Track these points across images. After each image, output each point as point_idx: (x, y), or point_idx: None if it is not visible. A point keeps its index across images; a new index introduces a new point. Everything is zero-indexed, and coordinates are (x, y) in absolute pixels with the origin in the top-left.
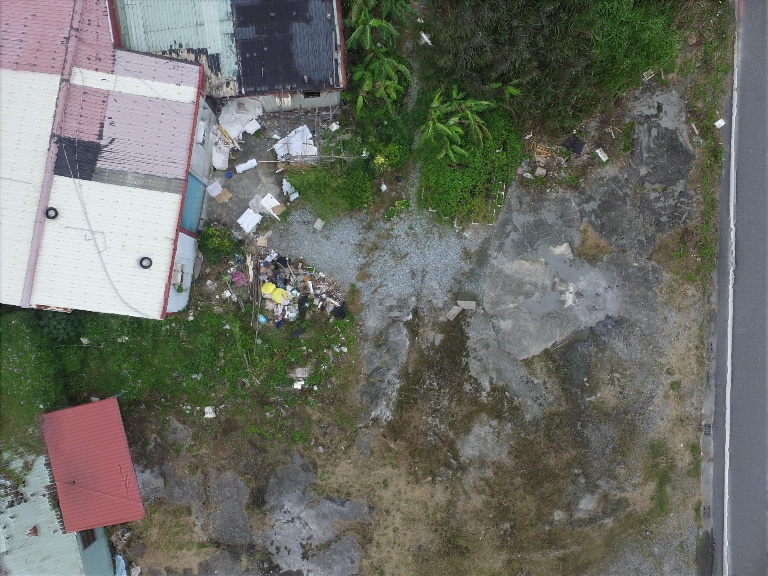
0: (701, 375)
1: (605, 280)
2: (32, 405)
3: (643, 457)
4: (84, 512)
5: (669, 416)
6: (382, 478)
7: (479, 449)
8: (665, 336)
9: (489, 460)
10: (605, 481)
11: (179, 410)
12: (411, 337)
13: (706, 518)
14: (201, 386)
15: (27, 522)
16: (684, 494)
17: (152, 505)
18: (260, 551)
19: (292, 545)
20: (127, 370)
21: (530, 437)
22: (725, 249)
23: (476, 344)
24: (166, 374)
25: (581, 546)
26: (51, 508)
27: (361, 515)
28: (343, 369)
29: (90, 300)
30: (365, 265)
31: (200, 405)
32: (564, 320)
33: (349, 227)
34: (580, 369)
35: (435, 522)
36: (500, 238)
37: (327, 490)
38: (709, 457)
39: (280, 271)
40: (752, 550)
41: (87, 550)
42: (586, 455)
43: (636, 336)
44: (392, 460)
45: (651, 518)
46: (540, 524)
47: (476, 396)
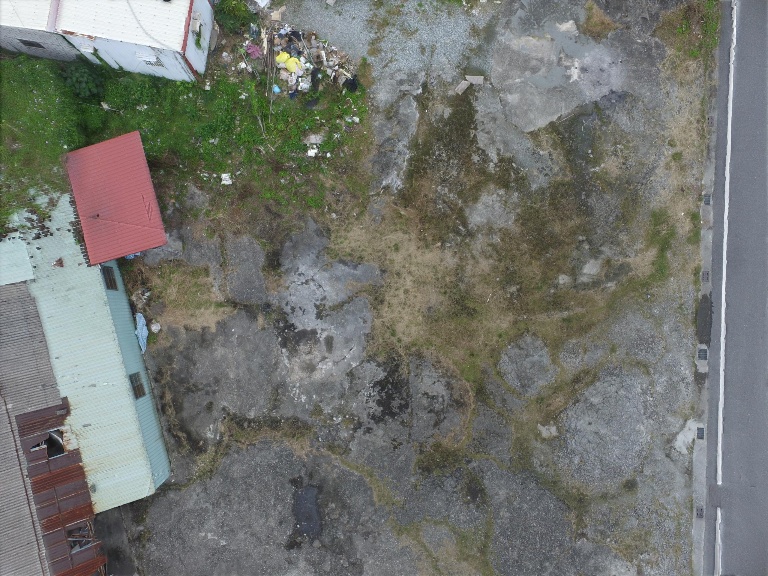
0: (702, 148)
1: (609, 56)
2: (57, 145)
3: (645, 225)
4: (108, 243)
5: (670, 186)
6: (393, 243)
7: (487, 216)
8: (667, 110)
9: (496, 227)
10: (608, 247)
11: (196, 177)
12: (421, 110)
13: (705, 283)
14: (218, 151)
15: (53, 254)
16: (684, 260)
17: (171, 266)
18: (275, 311)
19: (306, 306)
20: (147, 128)
21: (536, 205)
22: (726, 28)
23: (484, 117)
24: (184, 139)
25: (585, 308)
26: (76, 242)
27: (373, 278)
28: (355, 139)
29: (113, 29)
30: (376, 40)
31: (217, 172)
32: (569, 94)
33: (361, 3)
34: (585, 142)
35: (444, 285)
36: (507, 15)
37: (340, 254)
38: (709, 226)
39: (294, 43)
40: (749, 312)
41: (110, 292)
42: (590, 223)
43: (639, 110)
44: (403, 226)
45: (652, 282)
46: (545, 287)
47: (484, 167)
